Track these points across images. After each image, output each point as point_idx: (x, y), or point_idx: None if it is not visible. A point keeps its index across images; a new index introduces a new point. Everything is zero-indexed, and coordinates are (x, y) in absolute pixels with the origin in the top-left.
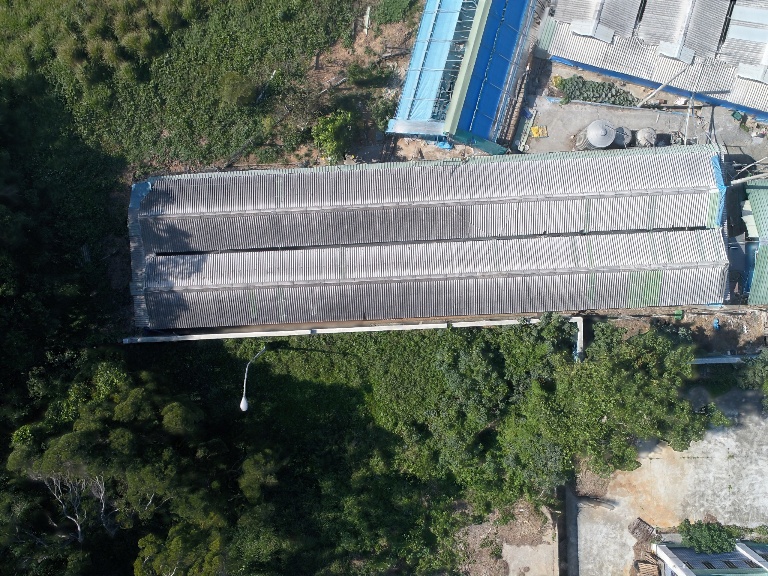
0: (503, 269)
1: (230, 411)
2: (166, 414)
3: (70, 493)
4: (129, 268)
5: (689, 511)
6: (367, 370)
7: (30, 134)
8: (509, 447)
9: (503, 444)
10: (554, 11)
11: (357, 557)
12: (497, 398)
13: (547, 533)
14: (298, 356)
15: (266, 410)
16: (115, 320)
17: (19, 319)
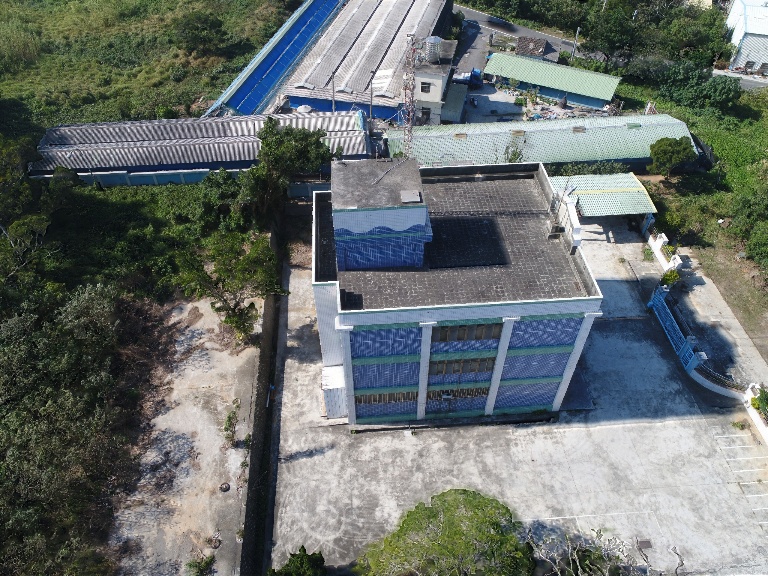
0: None
1: None
2: None
3: None
4: None
5: None
6: (158, 196)
7: (5, 116)
8: None
9: (232, 212)
10: (287, 83)
11: None
12: None
13: None
14: (116, 190)
15: None
16: None
17: None
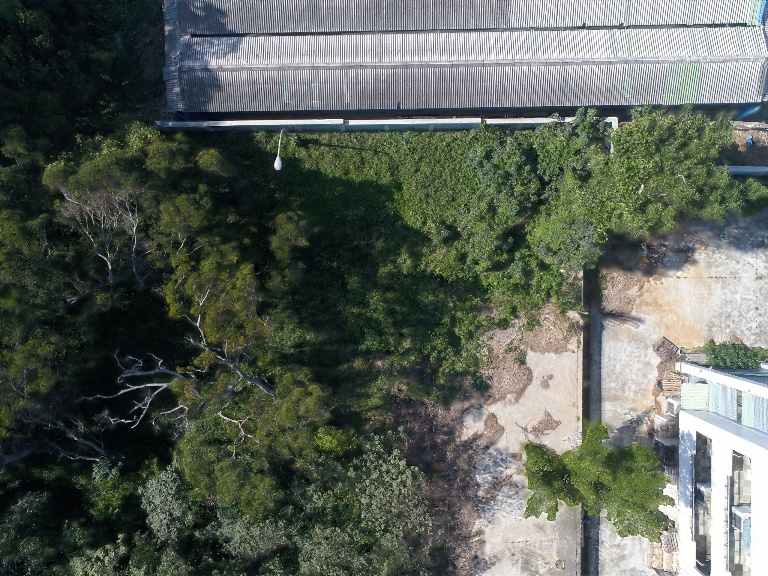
0: (541, 57)
1: (258, 203)
2: (201, 158)
3: (102, 230)
4: (162, 58)
5: (715, 332)
6: (398, 169)
7: None
8: (539, 242)
9: (533, 242)
10: None
11: (380, 357)
12: (529, 192)
13: (572, 341)
14: (329, 152)
15: (294, 205)
16: (146, 110)
17: (53, 78)
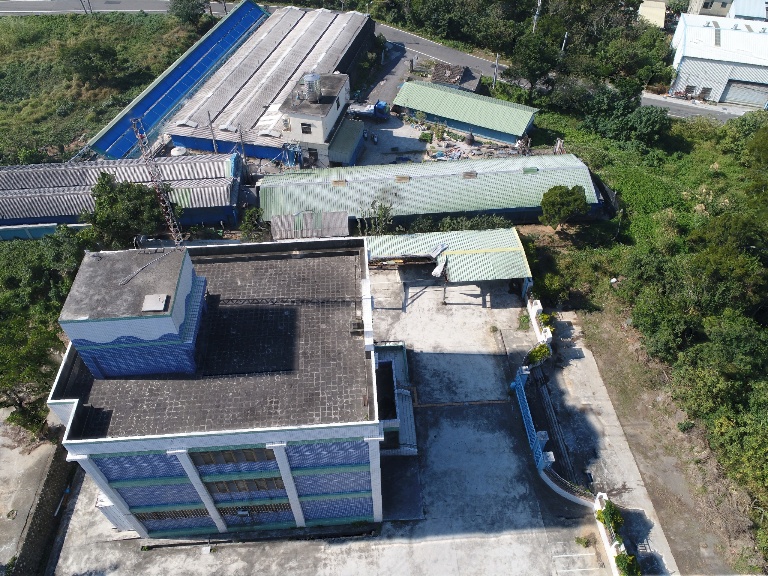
0: None
1: None
2: None
3: None
4: None
5: None
6: None
7: None
8: None
9: None
10: None
11: None
12: None
13: None
14: None
15: None
16: None
17: None
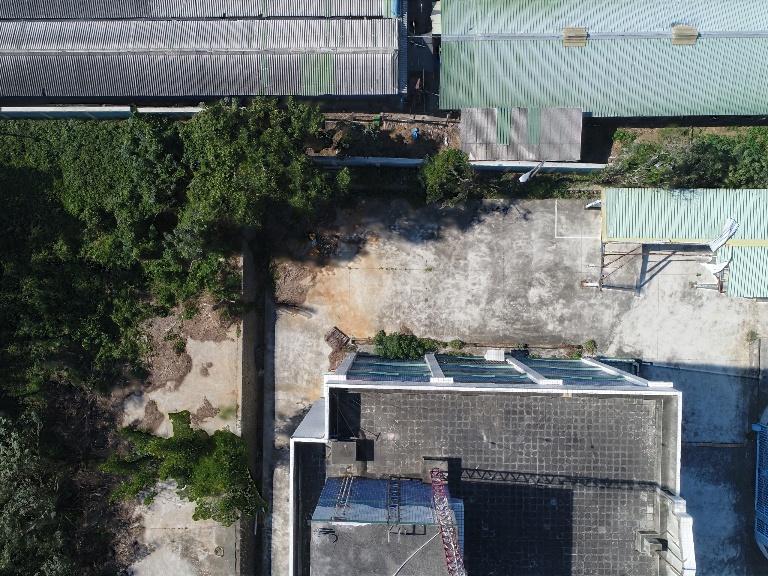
0: (176, 47)
1: None
2: None
3: None
4: None
5: (385, 323)
6: (58, 156)
7: None
8: None
9: None
10: None
11: None
12: (171, 180)
13: (232, 330)
14: None
15: None
16: None
17: None
